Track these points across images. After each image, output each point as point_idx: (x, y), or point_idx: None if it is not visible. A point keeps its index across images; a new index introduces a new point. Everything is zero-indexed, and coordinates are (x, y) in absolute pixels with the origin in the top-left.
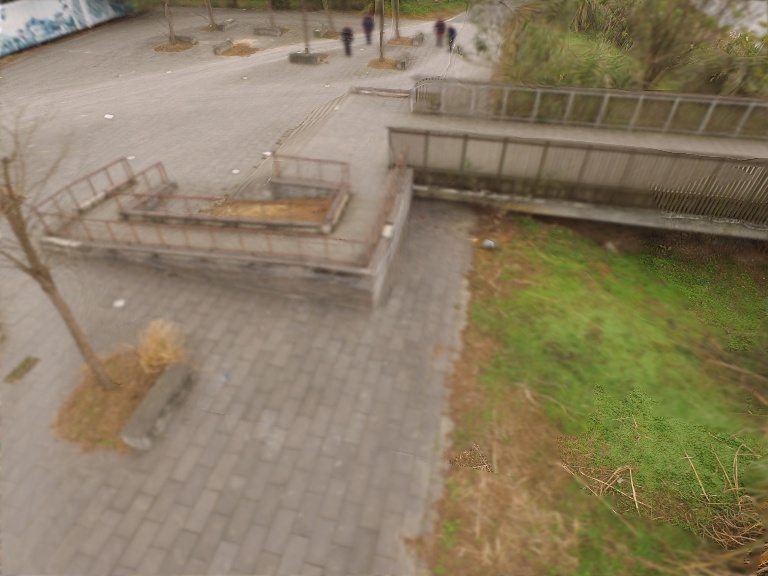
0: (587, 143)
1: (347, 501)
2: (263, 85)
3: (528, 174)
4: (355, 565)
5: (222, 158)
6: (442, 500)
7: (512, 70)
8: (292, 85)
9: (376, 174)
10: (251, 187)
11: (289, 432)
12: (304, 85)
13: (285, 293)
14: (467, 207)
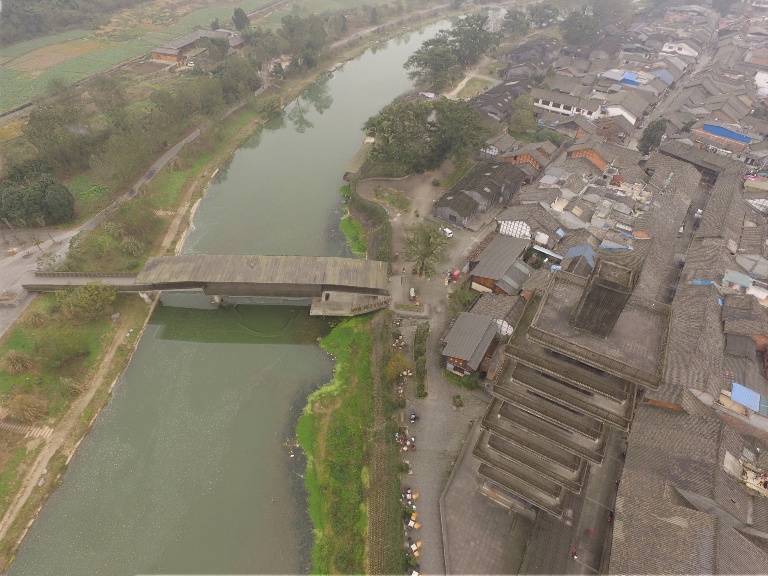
0: (45, 284)
1: (8, 321)
2: (14, 267)
3: (40, 288)
4: (7, 324)
5: (2, 288)
6: (16, 320)
7: (47, 270)
8: (21, 266)
9: (19, 291)
10: (4, 294)
11: (4, 318)
12: (24, 266)
13: (7, 307)
14: (37, 292)
